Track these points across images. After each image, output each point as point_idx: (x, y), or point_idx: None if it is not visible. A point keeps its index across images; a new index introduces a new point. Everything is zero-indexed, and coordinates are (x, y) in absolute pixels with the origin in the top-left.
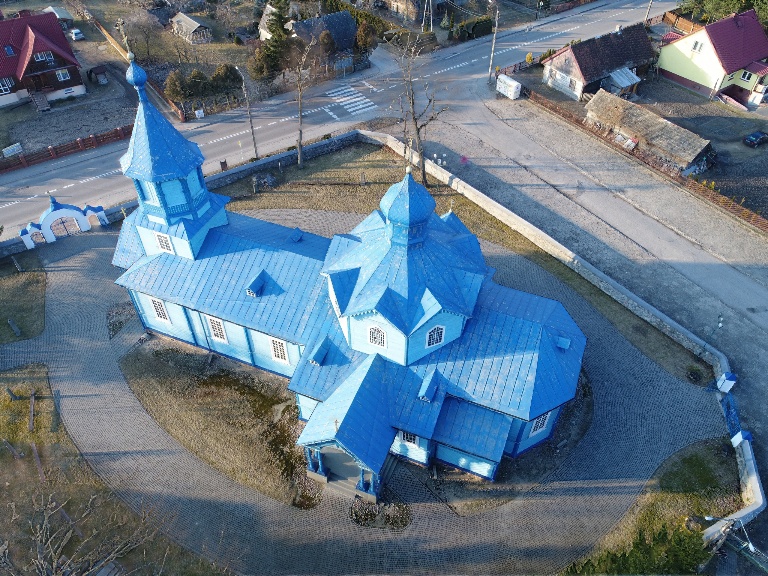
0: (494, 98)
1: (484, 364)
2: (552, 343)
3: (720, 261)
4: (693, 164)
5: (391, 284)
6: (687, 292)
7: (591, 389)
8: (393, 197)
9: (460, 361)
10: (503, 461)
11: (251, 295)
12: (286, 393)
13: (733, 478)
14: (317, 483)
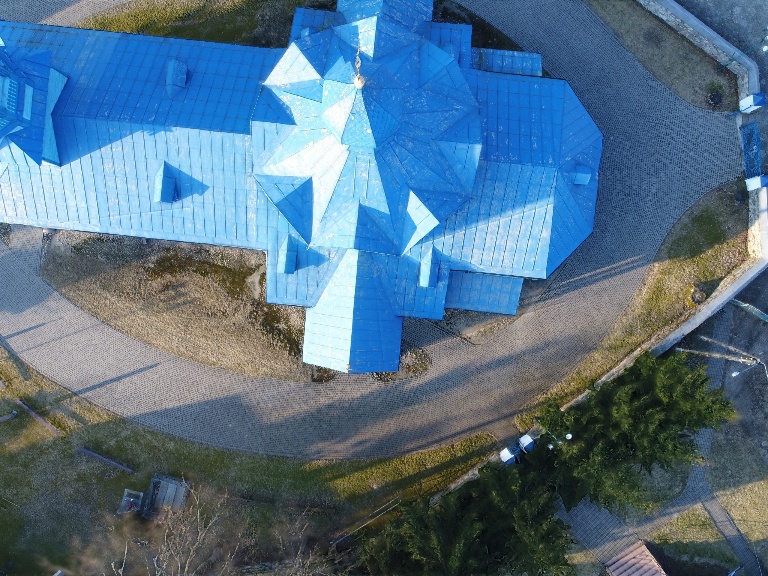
0: None
1: (489, 229)
2: (568, 184)
3: None
4: None
5: (363, 200)
6: None
7: None
8: (342, 117)
9: (460, 232)
10: None
11: None
12: (253, 259)
13: (742, 228)
14: None
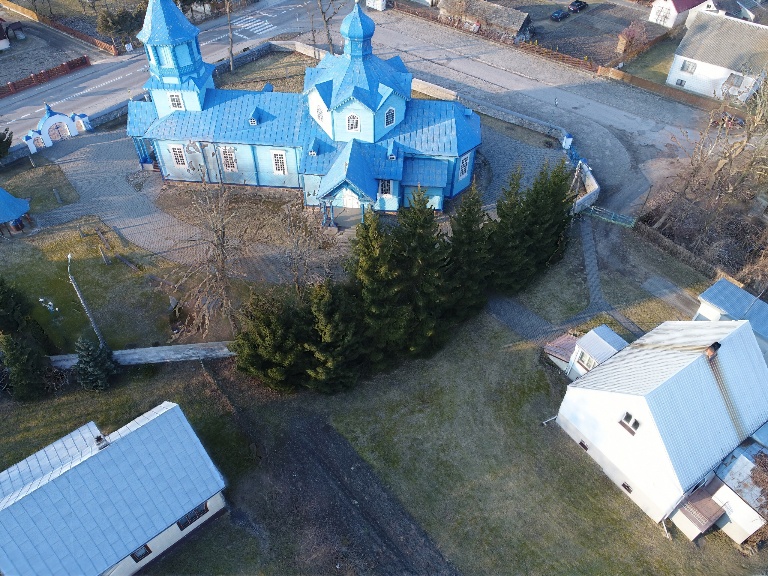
0: (367, 11)
1: (423, 132)
2: (461, 112)
3: (550, 86)
4: (521, 33)
5: (357, 84)
6: (534, 105)
7: (488, 161)
8: (349, 21)
9: (408, 133)
10: (445, 203)
11: (253, 124)
12: (288, 198)
13: (581, 185)
14: (331, 236)
